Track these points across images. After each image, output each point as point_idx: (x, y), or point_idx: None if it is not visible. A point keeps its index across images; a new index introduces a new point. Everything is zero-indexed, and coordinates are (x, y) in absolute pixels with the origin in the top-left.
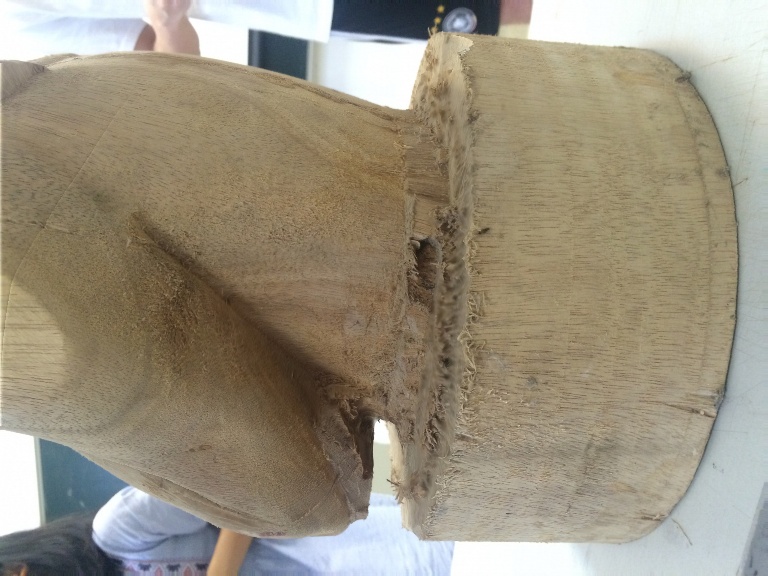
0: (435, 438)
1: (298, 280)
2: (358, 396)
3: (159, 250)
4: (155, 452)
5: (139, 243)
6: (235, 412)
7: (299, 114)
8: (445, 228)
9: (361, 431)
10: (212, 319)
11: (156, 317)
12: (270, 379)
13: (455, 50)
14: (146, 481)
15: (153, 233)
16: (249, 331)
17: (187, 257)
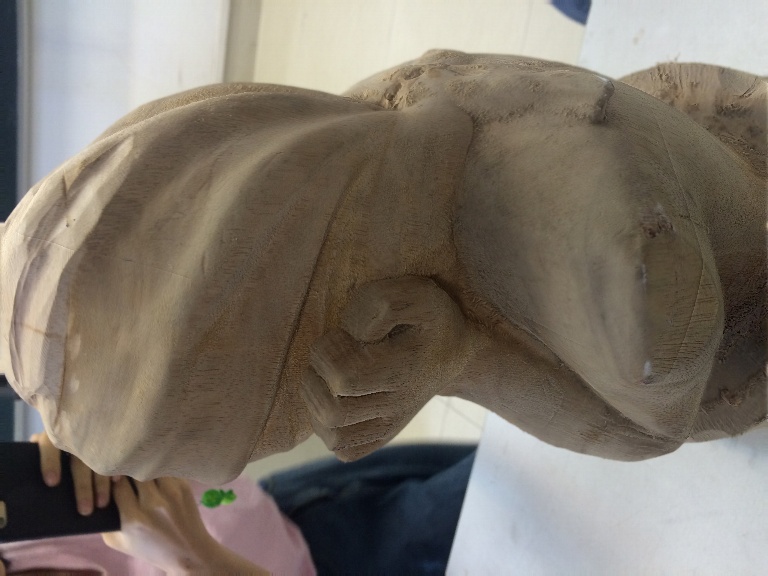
0: None
1: (728, 254)
2: None
3: None
4: None
5: None
6: None
7: (702, 127)
8: None
9: None
10: None
11: None
12: None
13: (733, 80)
14: (588, 430)
15: None
16: None
17: None
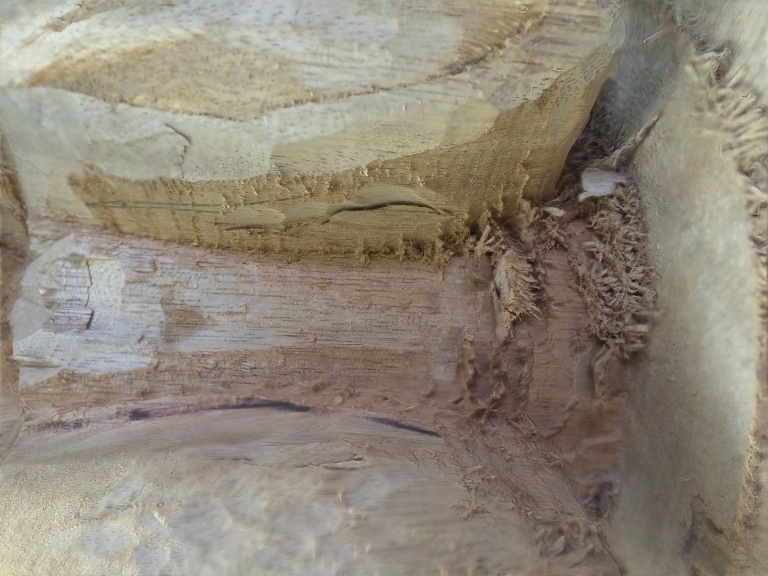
0: None
1: None
2: None
3: None
4: None
5: None
6: None
7: None
8: None
9: None
10: None
11: None
12: None
13: None
14: None
15: None
16: None
17: None
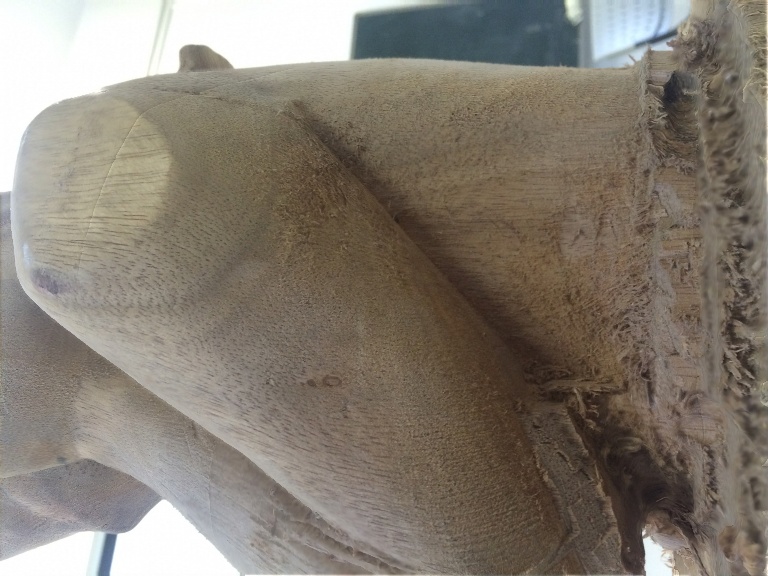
0: (748, 369)
1: (490, 178)
2: (598, 388)
3: (315, 136)
4: (257, 375)
5: (292, 117)
6: (382, 322)
7: None
8: (698, 52)
9: (611, 467)
10: (368, 213)
11: (291, 173)
12: (445, 311)
13: None
14: (256, 532)
15: (313, 125)
16: (421, 257)
17: (348, 154)
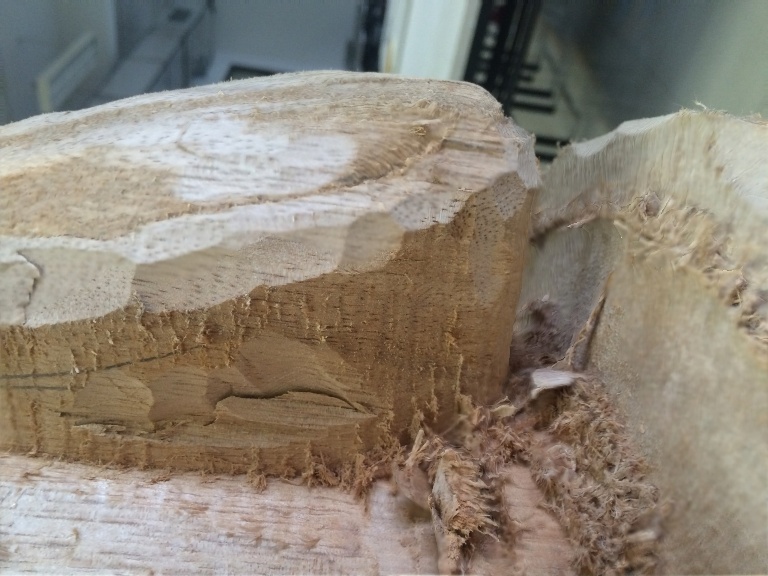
0: None
1: None
2: None
3: None
4: None
5: None
6: None
7: None
8: None
9: None
10: None
11: None
12: None
13: None
14: None
15: None
16: None
17: None
